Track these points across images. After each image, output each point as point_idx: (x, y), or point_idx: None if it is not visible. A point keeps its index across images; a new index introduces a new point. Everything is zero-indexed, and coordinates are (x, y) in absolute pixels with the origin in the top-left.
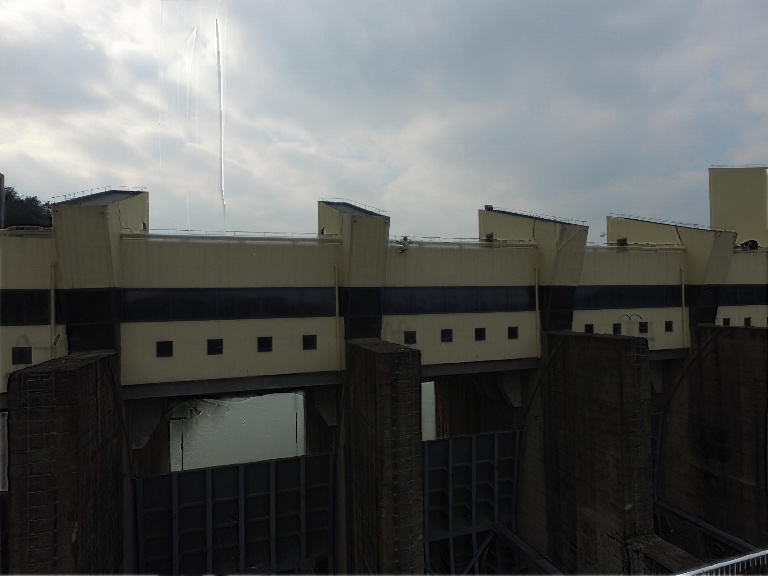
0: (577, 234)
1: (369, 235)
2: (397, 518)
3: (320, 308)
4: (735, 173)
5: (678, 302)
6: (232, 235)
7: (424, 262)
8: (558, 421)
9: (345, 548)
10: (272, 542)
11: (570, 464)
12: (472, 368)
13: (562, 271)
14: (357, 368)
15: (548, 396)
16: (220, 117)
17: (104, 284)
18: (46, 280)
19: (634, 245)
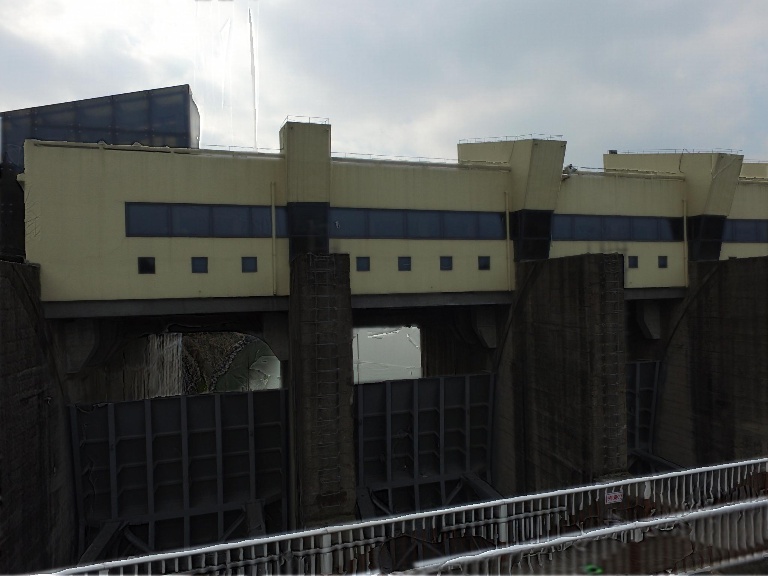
0: (732, 163)
1: (546, 158)
2: (606, 407)
3: (491, 232)
4: None
5: None
6: (416, 161)
7: (582, 191)
8: (711, 345)
9: (513, 458)
10: (441, 453)
11: (727, 384)
12: (625, 295)
13: (715, 200)
14: (542, 281)
15: (698, 323)
16: (254, 107)
17: (322, 199)
18: (266, 197)
19: None
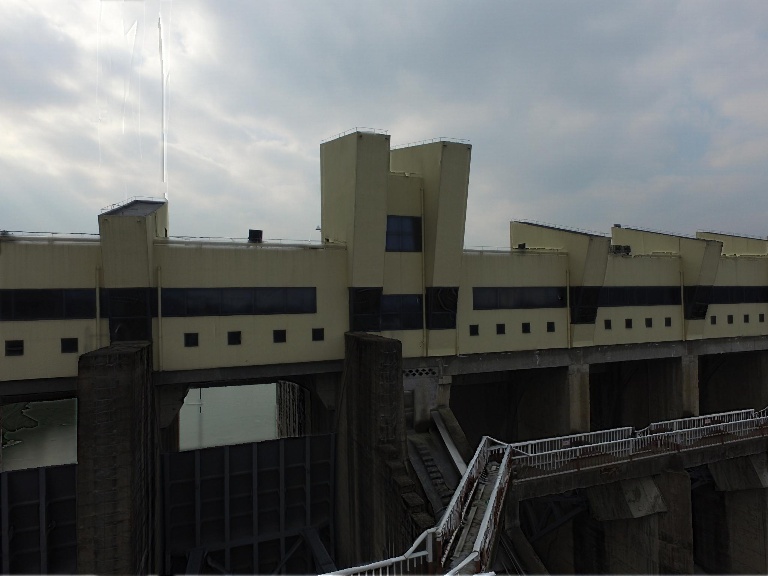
0: None
1: None
2: None
3: None
4: (327, 149)
5: None
6: None
7: None
8: None
9: None
10: None
11: None
12: None
13: None
14: None
15: None
16: (162, 114)
17: None
18: None
19: (2, 233)
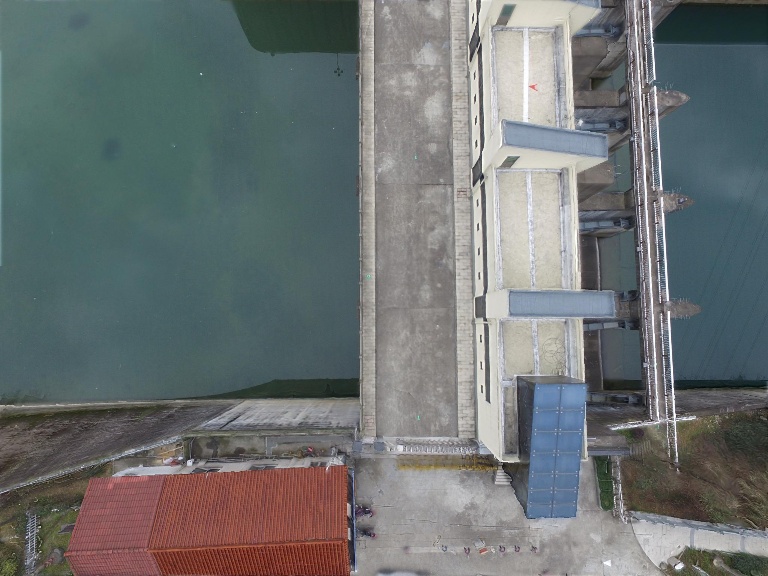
0: None
1: None
2: None
3: None
4: None
5: None
6: None
7: None
8: None
9: None
10: None
11: None
12: None
13: None
14: None
15: None
16: None
17: None
18: None
19: None
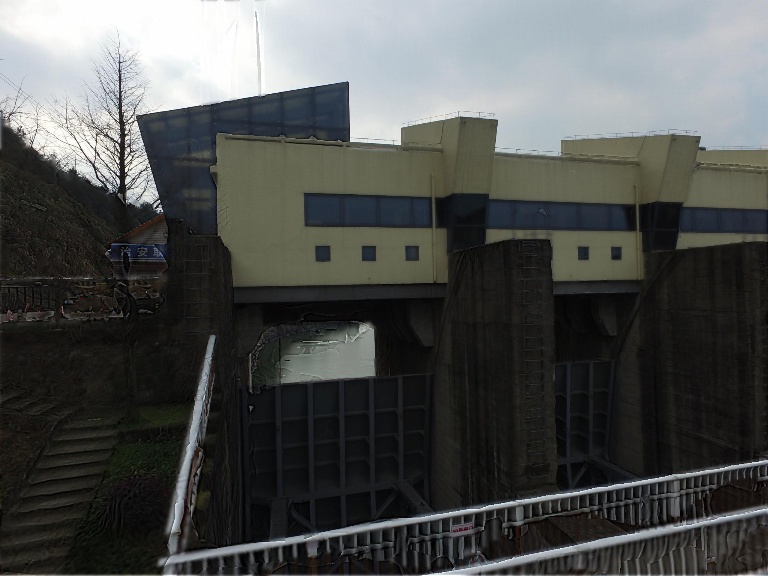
0: None
1: (682, 153)
2: (767, 386)
3: (622, 223)
4: None
5: None
6: (556, 155)
7: (702, 185)
8: None
9: (640, 440)
10: (568, 436)
11: None
12: None
13: None
14: (683, 269)
15: None
16: None
17: (483, 190)
18: (426, 189)
19: None
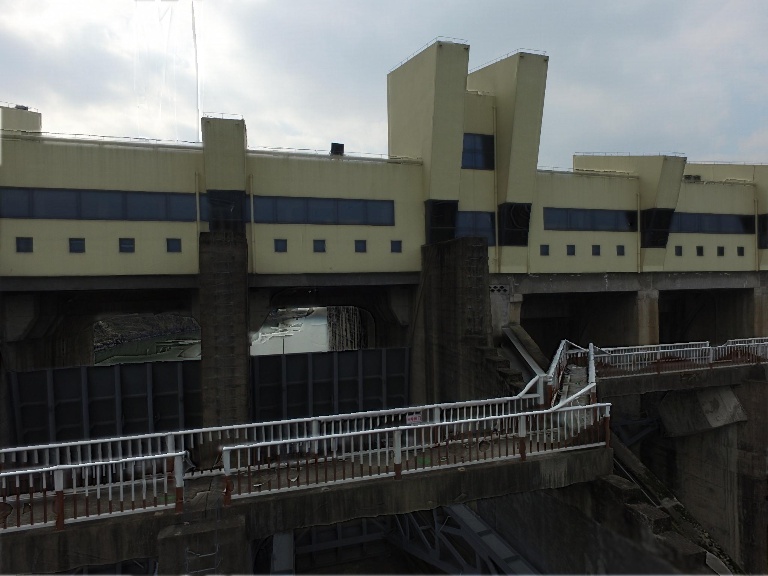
0: None
1: None
2: None
3: None
4: (396, 75)
5: (196, 216)
6: None
7: None
8: None
9: None
10: None
11: None
12: None
13: None
14: None
15: None
16: (197, 98)
17: None
18: None
19: (113, 139)
